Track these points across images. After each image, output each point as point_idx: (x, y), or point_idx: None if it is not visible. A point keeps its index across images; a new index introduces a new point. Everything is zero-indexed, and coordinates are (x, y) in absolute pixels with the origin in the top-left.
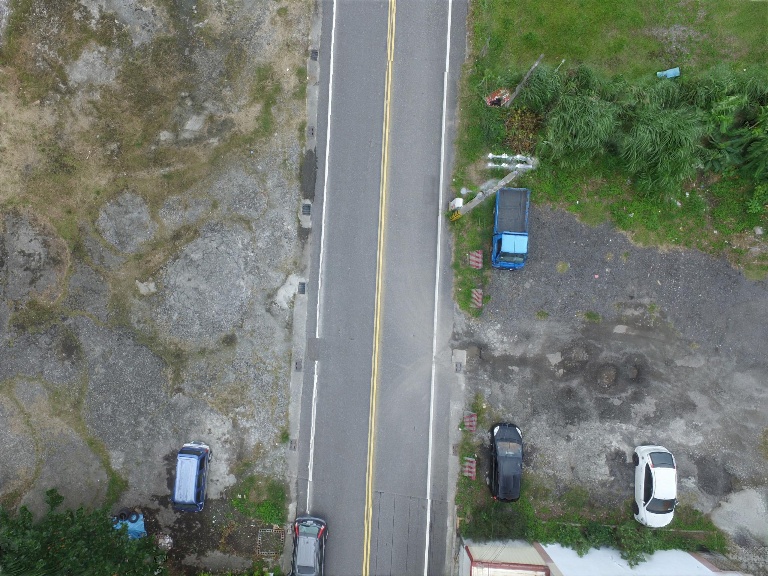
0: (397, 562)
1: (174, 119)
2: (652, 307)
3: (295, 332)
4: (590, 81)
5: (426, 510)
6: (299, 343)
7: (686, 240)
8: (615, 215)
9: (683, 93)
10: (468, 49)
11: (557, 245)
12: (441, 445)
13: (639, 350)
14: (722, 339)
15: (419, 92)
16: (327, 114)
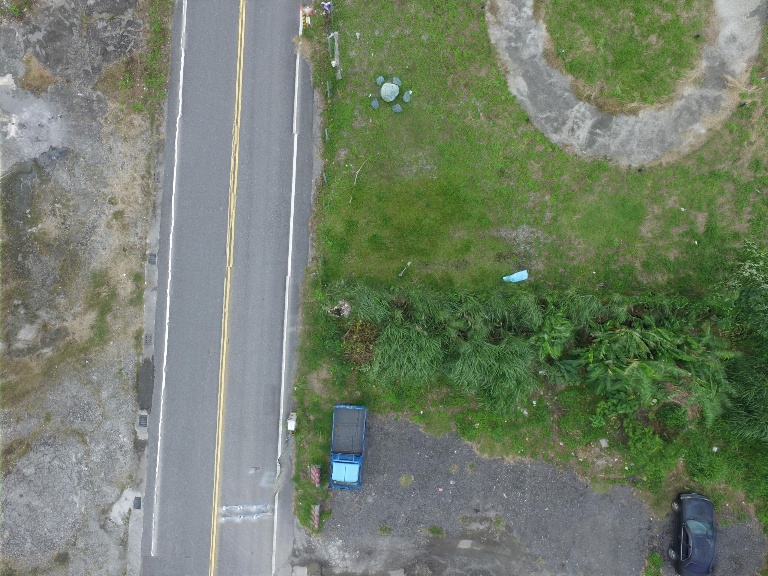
0: None
1: (6, 328)
2: (497, 521)
3: (130, 549)
4: (419, 307)
5: None
6: (134, 561)
7: (532, 452)
8: (458, 427)
9: (520, 312)
10: (311, 251)
11: (401, 457)
12: None
13: (484, 566)
14: (569, 555)
15: (260, 297)
16: (165, 321)
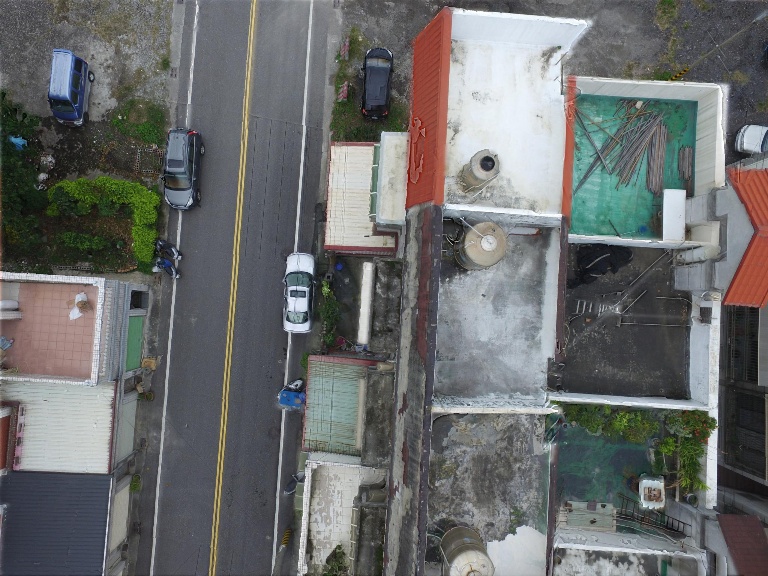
0: (272, 183)
1: None
2: None
3: None
4: None
5: (301, 135)
6: None
7: None
8: None
9: None
10: None
11: None
12: (318, 75)
13: None
14: None
15: None
16: None
